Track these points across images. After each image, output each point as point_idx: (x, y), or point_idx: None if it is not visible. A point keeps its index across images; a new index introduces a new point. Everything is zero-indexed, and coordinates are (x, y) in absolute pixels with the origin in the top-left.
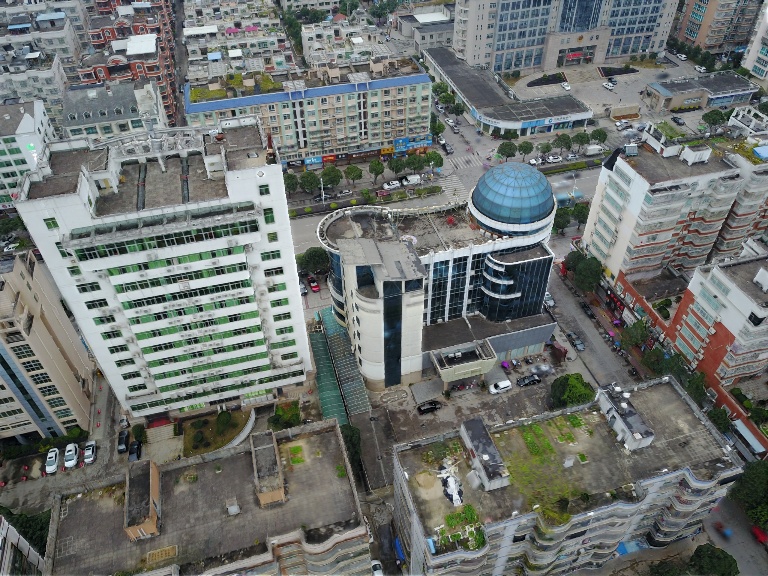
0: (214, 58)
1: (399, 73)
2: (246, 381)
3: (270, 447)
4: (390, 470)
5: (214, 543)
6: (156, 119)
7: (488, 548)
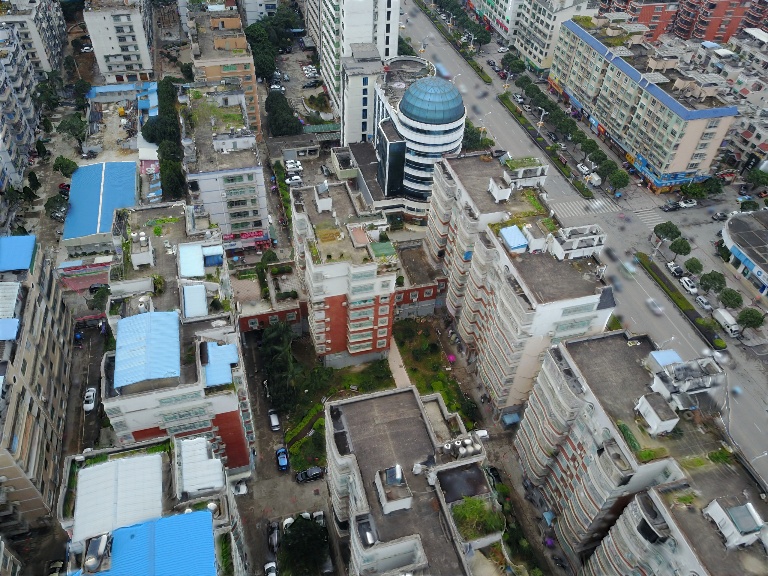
0: (705, 45)
1: (683, 98)
2: (331, 89)
3: (237, 37)
4: (276, 145)
5: (204, 38)
6: (552, 16)
7: (181, 101)
